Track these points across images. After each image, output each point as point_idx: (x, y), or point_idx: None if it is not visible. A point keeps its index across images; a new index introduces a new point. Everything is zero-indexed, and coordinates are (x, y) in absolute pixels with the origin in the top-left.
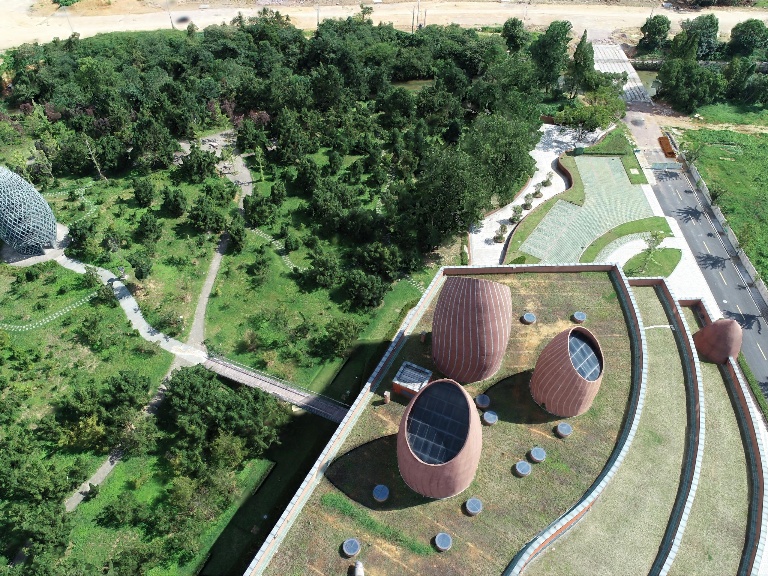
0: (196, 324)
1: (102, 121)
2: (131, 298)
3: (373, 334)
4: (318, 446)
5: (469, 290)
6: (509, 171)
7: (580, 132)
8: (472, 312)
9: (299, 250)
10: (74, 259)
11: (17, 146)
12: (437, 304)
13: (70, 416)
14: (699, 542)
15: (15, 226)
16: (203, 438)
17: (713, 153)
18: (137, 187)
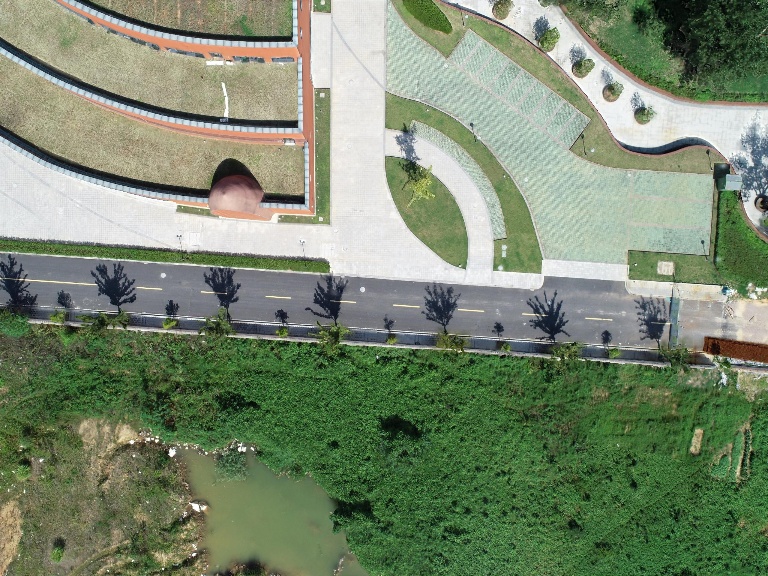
0: None
1: None
2: None
3: None
4: None
5: None
6: None
7: None
8: None
9: None
10: None
11: None
12: None
13: None
14: (1, 81)
15: None
16: None
17: (715, 424)
18: None
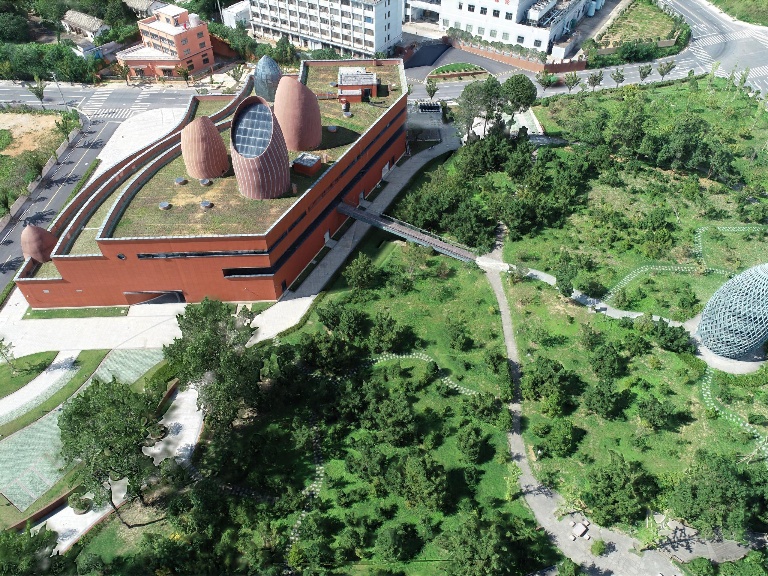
0: (499, 286)
1: None
2: (572, 297)
3: (336, 297)
4: None
5: None
6: None
7: None
8: None
9: None
10: None
11: None
12: None
13: (554, 221)
14: None
15: None
16: None
17: None
18: None
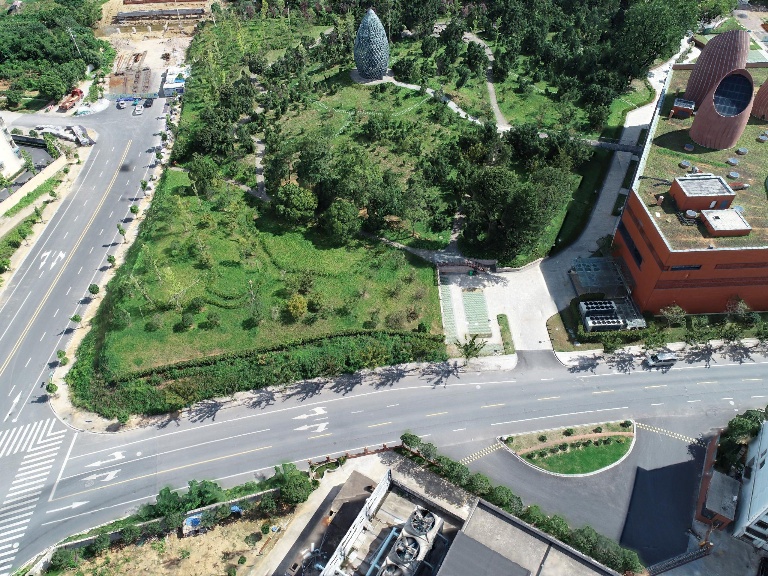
0: (498, 115)
1: (372, 8)
2: (451, 101)
3: (610, 123)
4: (605, 169)
5: (732, 38)
6: (683, 26)
7: (705, 20)
8: (732, 52)
9: (540, 82)
10: (402, 82)
11: (307, 29)
12: (701, 58)
13: None
14: None
15: (377, 54)
16: (544, 156)
17: None
18: (424, 43)
